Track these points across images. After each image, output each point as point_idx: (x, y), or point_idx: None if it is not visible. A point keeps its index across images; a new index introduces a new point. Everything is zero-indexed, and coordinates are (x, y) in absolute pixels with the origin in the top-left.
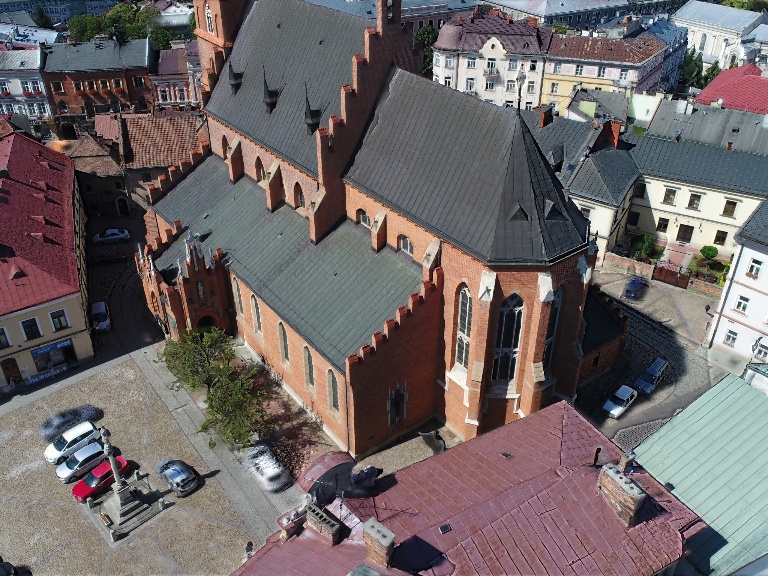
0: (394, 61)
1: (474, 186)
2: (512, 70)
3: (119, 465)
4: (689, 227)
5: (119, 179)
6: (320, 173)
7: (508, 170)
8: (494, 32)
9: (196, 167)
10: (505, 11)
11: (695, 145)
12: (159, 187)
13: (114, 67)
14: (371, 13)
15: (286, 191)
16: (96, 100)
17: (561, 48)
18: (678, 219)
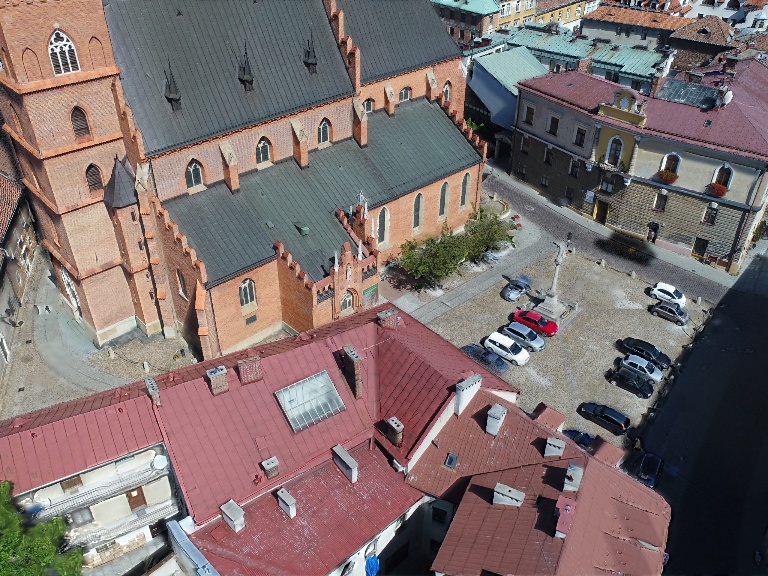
0: None
1: None
2: None
3: (524, 312)
4: None
5: None
6: None
7: None
8: None
9: None
10: None
11: None
12: None
13: None
14: None
15: (307, 140)
16: None
17: None
18: None
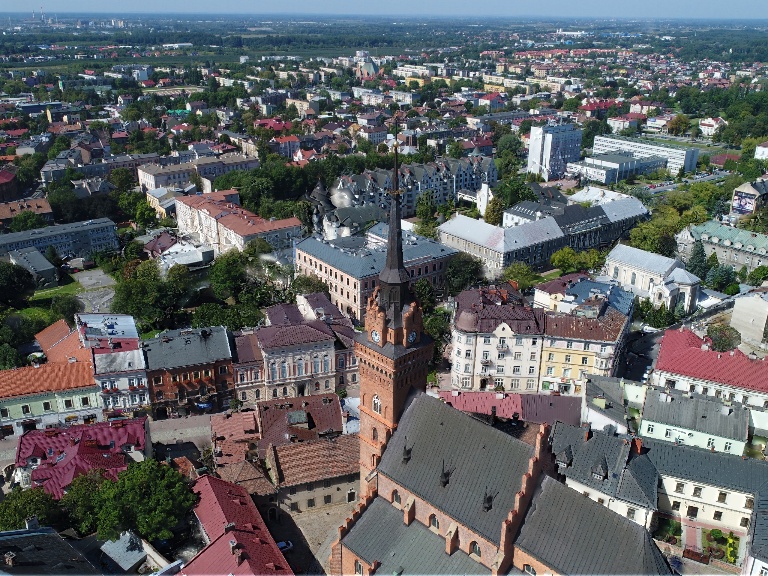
0: (542, 469)
1: (621, 569)
2: (518, 345)
3: None
4: (695, 508)
5: (273, 495)
6: (502, 544)
7: (644, 563)
8: (503, 318)
9: (368, 507)
10: (468, 244)
11: (691, 449)
12: (345, 527)
13: (206, 361)
14: (374, 268)
15: (461, 542)
16: (188, 387)
17: (554, 328)
18: (687, 502)
